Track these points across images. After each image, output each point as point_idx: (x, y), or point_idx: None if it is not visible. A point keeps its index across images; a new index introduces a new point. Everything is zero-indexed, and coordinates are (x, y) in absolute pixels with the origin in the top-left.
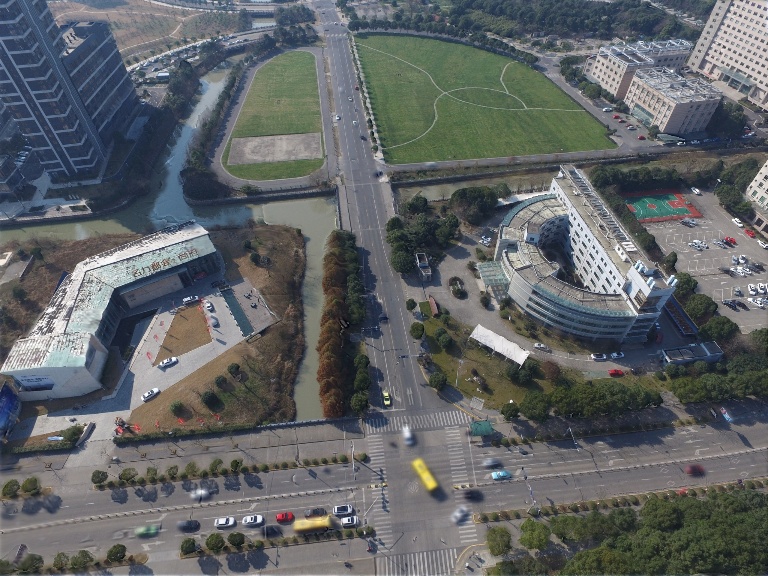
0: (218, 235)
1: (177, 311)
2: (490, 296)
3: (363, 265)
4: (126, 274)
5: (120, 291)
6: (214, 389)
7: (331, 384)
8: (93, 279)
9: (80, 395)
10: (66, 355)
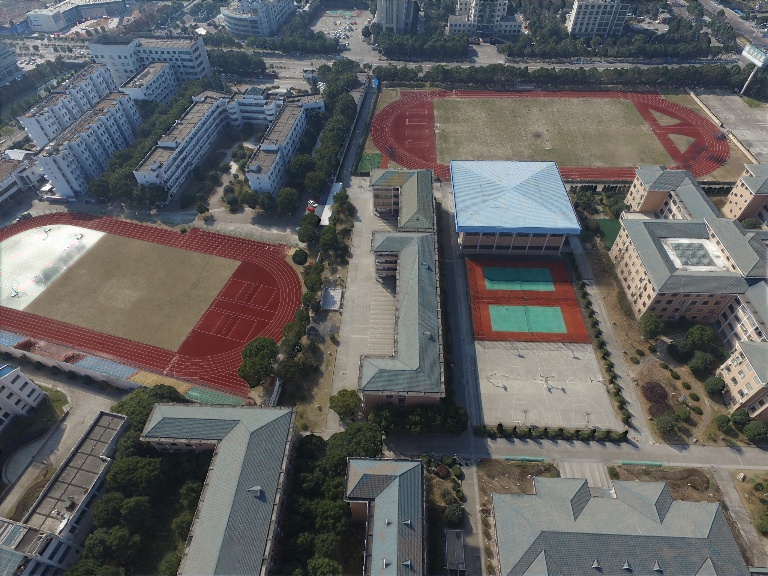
0: (135, 5)
1: (99, 20)
2: (221, 26)
3: (182, 16)
4: (84, 2)
5: (79, 7)
6: (93, 32)
7: (127, 28)
8: (71, 2)
9: (51, 31)
10: (47, 12)
